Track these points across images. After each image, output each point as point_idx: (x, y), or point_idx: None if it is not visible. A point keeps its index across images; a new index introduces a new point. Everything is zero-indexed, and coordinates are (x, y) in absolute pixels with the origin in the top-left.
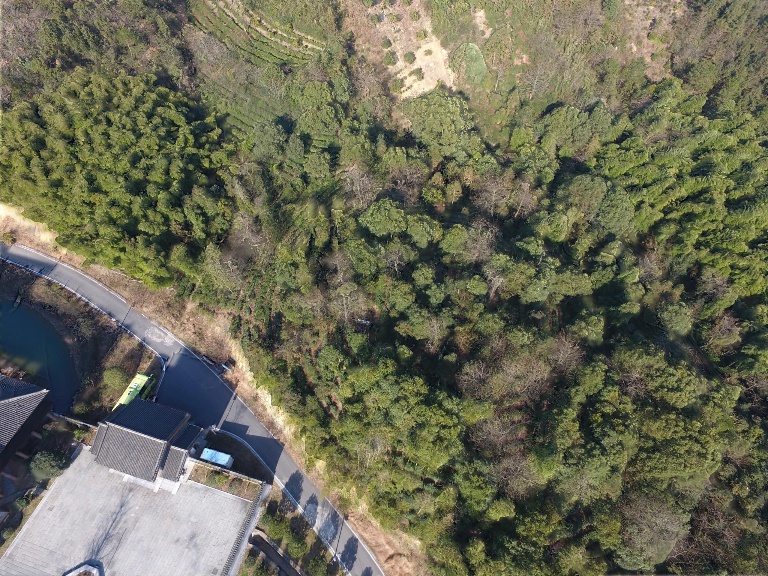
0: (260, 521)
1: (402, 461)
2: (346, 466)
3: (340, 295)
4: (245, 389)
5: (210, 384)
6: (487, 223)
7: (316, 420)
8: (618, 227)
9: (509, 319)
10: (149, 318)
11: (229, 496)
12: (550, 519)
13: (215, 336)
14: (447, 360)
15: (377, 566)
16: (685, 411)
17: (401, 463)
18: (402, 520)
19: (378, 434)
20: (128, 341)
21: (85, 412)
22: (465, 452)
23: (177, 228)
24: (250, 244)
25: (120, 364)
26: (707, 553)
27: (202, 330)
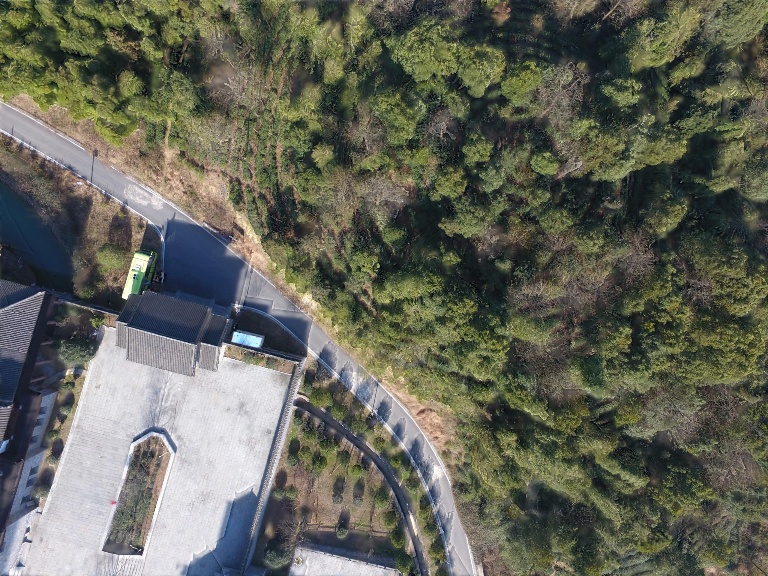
0: (301, 387)
1: (438, 349)
2: (382, 352)
3: (367, 169)
4: (261, 261)
5: (220, 256)
6: (576, 71)
7: (348, 310)
8: (739, 35)
9: (574, 203)
10: (122, 172)
11: (268, 370)
12: (578, 412)
13: (211, 196)
14: (499, 267)
15: (410, 417)
16: (741, 318)
17: (437, 350)
18: (435, 393)
19: (420, 345)
20: (108, 206)
21: (92, 296)
22: (508, 360)
23: (117, 41)
24: (237, 94)
25: (109, 235)
26: (706, 425)
27: (193, 188)
